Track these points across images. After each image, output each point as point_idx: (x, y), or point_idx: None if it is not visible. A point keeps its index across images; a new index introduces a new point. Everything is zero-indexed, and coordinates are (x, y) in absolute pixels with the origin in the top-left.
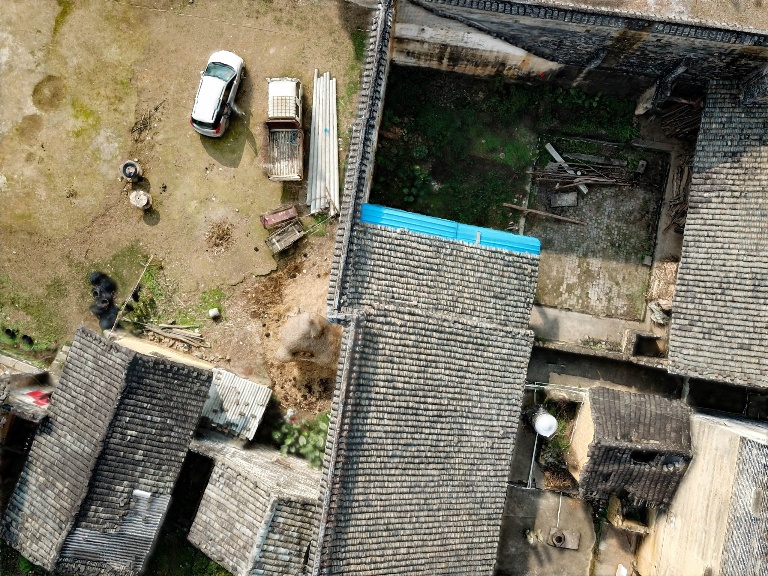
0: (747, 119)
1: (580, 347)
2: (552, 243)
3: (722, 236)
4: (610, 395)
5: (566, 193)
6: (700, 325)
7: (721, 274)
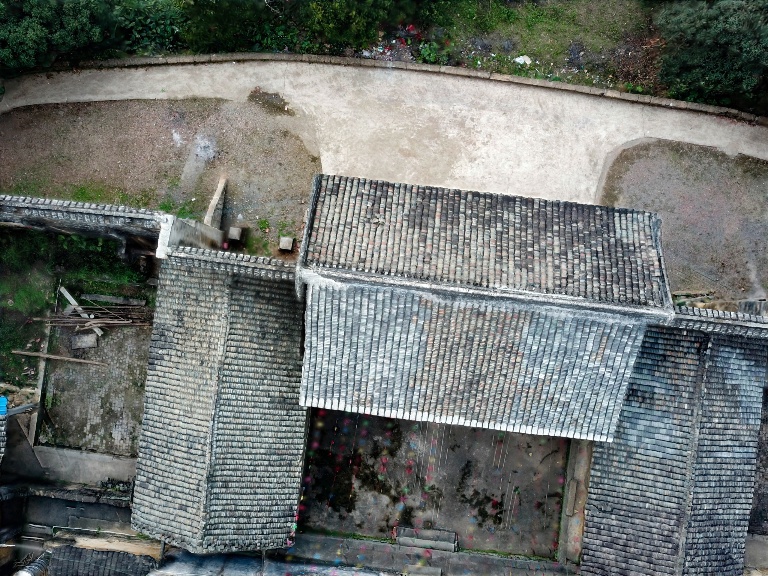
0: (188, 278)
1: (81, 495)
2: (74, 385)
3: (169, 395)
4: (71, 554)
5: (86, 335)
6: (153, 483)
7: (167, 433)
